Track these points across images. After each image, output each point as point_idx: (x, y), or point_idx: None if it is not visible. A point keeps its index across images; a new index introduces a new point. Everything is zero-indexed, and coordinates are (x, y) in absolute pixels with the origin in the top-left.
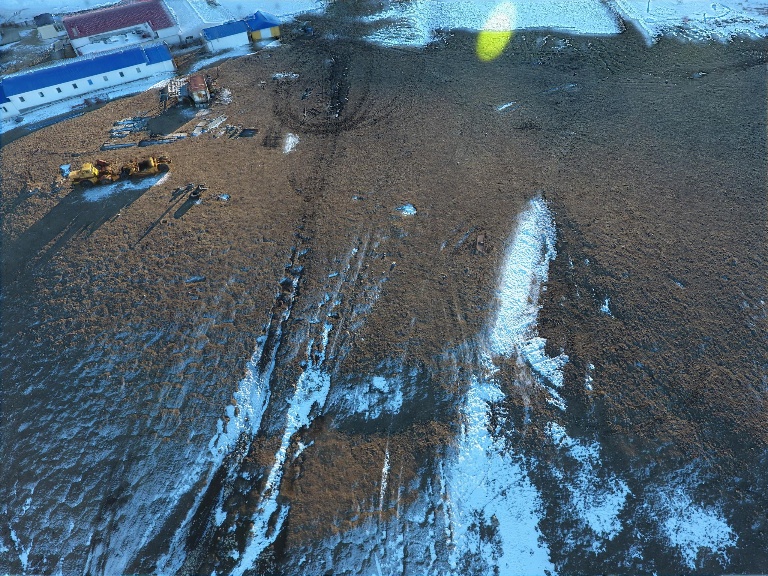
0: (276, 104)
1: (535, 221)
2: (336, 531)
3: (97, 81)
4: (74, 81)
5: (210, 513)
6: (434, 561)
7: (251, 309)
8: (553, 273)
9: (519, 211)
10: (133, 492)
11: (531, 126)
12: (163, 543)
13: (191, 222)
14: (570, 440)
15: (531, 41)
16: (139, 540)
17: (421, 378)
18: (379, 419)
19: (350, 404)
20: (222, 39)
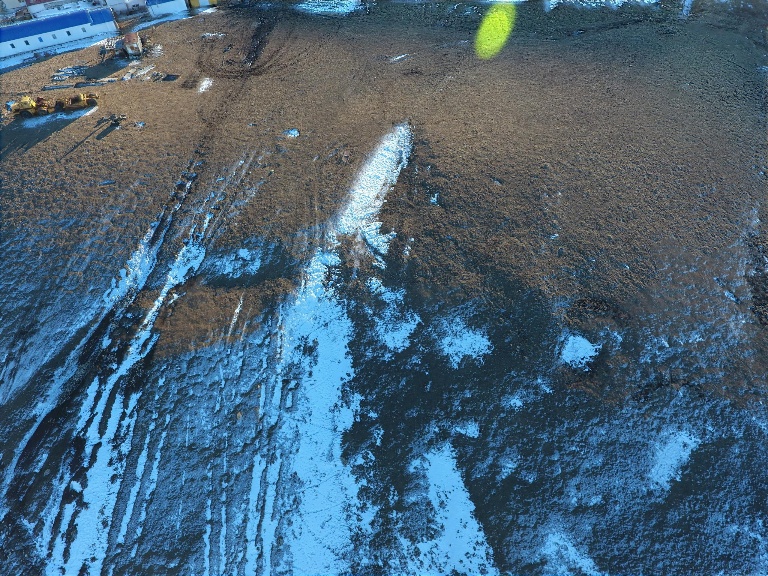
0: (200, 56)
1: (397, 141)
2: (192, 349)
3: (47, 39)
4: (26, 38)
5: (99, 340)
6: (264, 368)
7: (149, 203)
8: (401, 177)
9: (385, 133)
10: (41, 327)
11: (416, 72)
12: (61, 360)
13: (110, 142)
14: (383, 288)
15: (442, 8)
16: (43, 358)
17: (277, 249)
18: (239, 278)
19: (218, 268)
20: (161, 5)
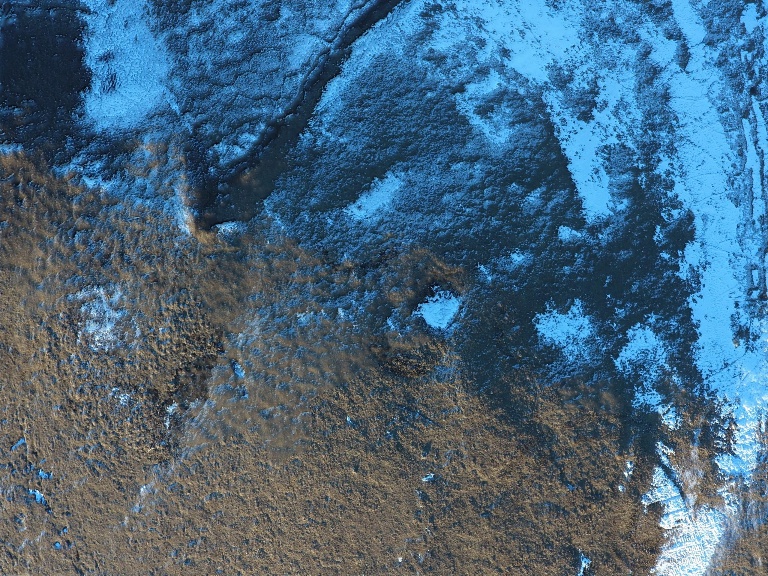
0: None
1: None
2: None
3: None
4: None
5: None
6: None
7: None
8: None
9: None
10: None
11: None
12: None
13: None
14: (660, 411)
15: None
16: None
17: None
18: None
19: None
20: None
